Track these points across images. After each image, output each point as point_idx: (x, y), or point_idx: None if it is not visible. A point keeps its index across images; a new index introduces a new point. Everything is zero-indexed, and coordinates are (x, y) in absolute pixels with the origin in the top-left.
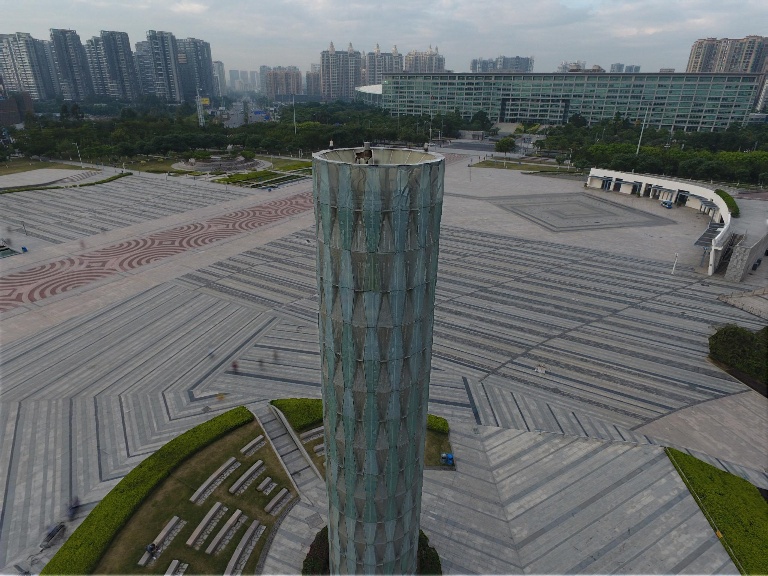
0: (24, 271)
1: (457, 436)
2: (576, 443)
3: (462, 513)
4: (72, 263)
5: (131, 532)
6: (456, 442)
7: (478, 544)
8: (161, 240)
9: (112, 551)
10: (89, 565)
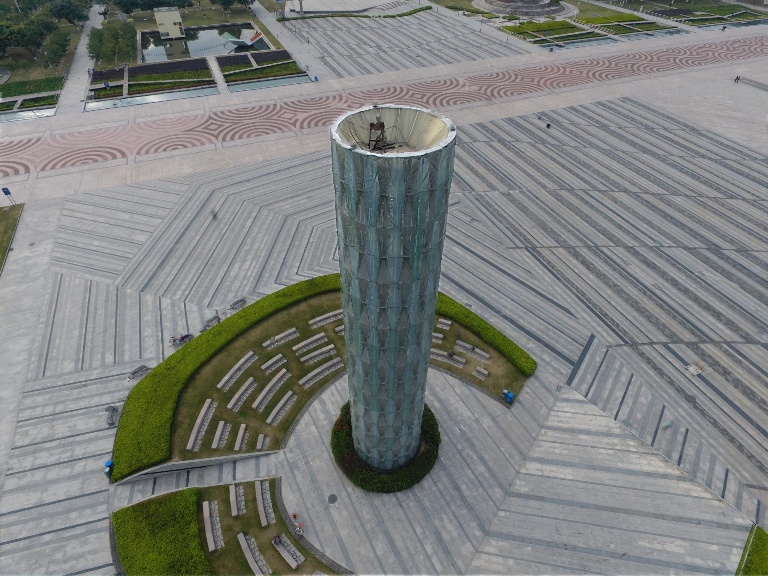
0: (308, 99)
1: (536, 383)
2: (651, 457)
3: (485, 442)
4: (340, 100)
5: (268, 324)
6: (531, 387)
7: (478, 470)
8: (414, 92)
9: (254, 329)
10: (239, 331)
